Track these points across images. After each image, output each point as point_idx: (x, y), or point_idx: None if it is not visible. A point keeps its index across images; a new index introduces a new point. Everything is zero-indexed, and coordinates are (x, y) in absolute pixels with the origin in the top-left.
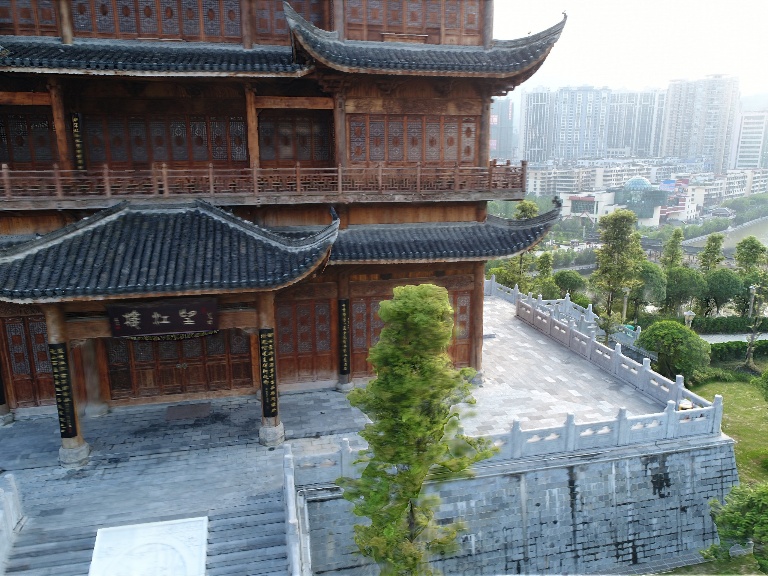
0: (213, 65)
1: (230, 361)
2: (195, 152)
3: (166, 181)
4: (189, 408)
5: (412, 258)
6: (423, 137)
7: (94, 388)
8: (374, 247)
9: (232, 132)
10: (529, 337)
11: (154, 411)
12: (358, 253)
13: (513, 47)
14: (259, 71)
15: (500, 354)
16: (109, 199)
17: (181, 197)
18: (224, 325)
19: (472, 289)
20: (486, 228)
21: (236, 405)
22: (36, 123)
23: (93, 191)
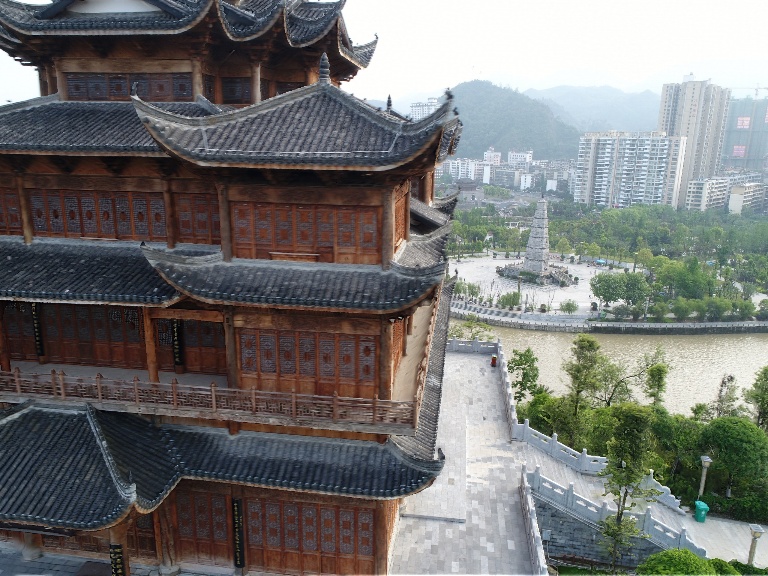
0: (90, 295)
1: (137, 533)
2: (129, 335)
3: (63, 385)
4: (99, 569)
5: (279, 485)
6: (316, 353)
7: (28, 535)
8: (249, 464)
9: (160, 320)
10: (503, 532)
11: (72, 565)
12: (226, 472)
13: (405, 274)
14: (129, 301)
15: (445, 557)
16: (19, 396)
17: (74, 400)
18: (82, 532)
19: (374, 508)
20: (382, 453)
21: (136, 575)
22: (8, 304)
23: (8, 388)
